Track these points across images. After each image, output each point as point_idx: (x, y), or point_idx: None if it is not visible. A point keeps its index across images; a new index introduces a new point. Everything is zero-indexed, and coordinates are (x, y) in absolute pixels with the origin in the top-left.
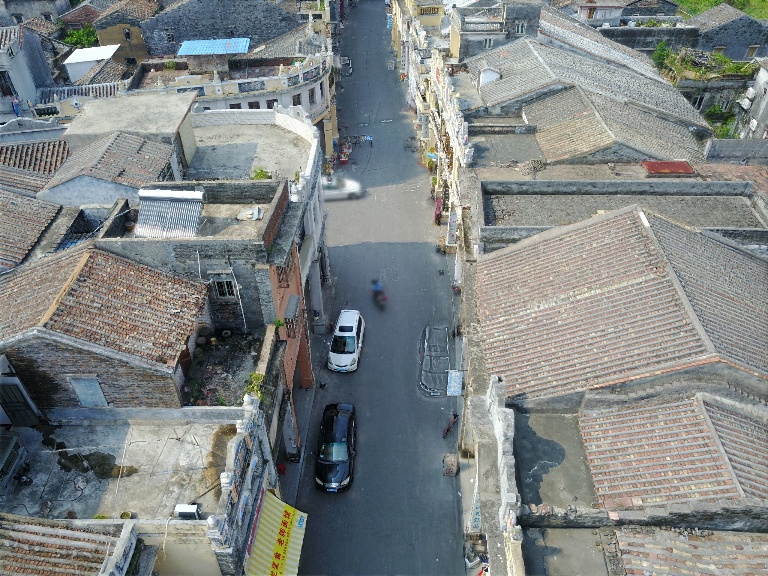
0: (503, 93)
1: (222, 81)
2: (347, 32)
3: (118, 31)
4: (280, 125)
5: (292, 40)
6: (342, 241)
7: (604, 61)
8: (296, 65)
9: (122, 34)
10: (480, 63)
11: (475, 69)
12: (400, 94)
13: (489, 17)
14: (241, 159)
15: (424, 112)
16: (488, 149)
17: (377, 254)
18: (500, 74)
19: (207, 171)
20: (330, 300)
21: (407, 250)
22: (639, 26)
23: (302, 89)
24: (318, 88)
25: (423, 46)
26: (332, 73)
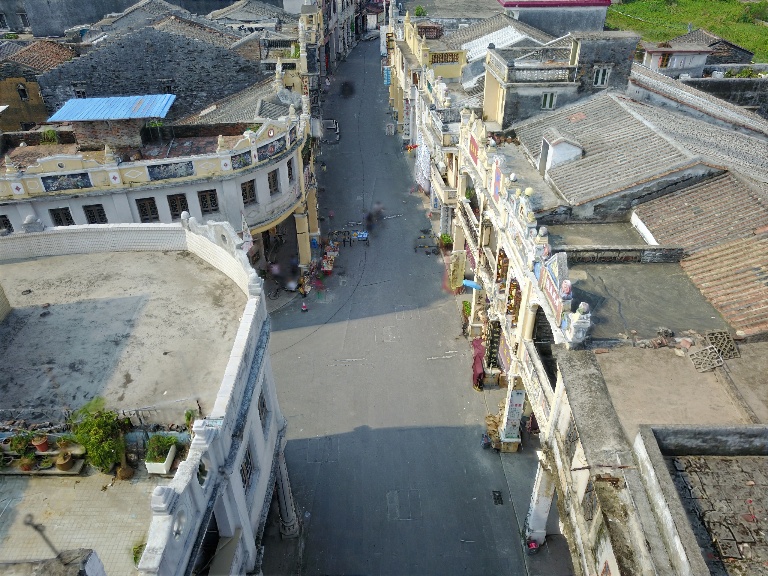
0: (595, 182)
1: (120, 163)
2: (334, 90)
3: (9, 87)
4: (195, 253)
5: (252, 98)
6: (321, 426)
7: (729, 126)
8: (245, 136)
9: (15, 91)
10: (546, 131)
11: (532, 139)
12: (403, 167)
13: (544, 62)
14: (92, 342)
15: (447, 202)
16: (601, 299)
17: (381, 455)
18: (582, 149)
19: (4, 379)
20: (295, 574)
21: (432, 444)
22: (730, 77)
23: (257, 172)
24: (284, 169)
25: (442, 105)
26: (307, 145)
